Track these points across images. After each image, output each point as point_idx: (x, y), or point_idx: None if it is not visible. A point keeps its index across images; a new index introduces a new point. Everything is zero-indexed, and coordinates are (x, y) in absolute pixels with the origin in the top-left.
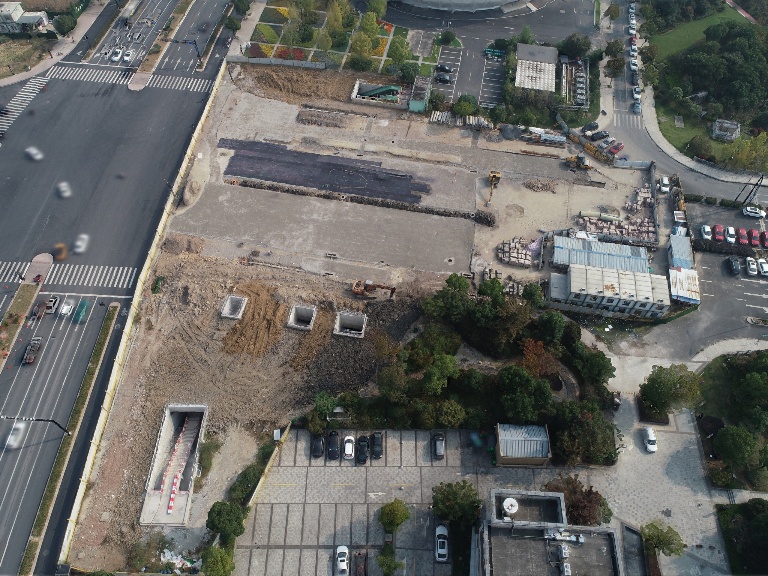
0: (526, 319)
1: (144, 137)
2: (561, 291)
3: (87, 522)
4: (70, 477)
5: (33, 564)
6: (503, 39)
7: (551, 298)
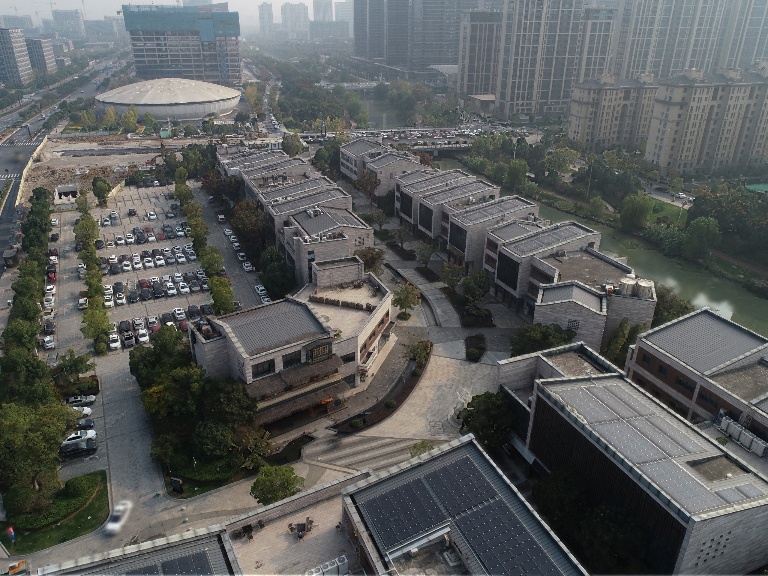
0: None
1: None
2: None
3: None
4: (8, 204)
5: None
6: (206, 121)
7: None
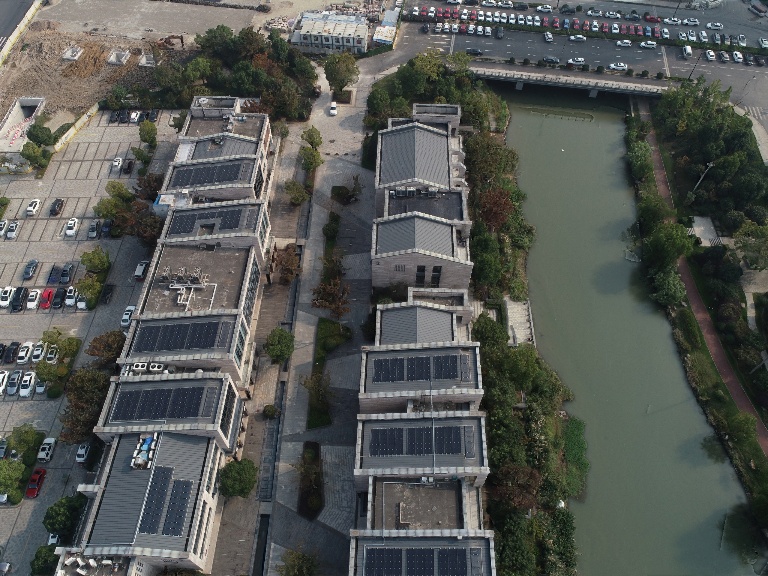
0: (259, 41)
1: None
2: (298, 39)
3: None
4: None
5: None
6: None
7: (291, 43)
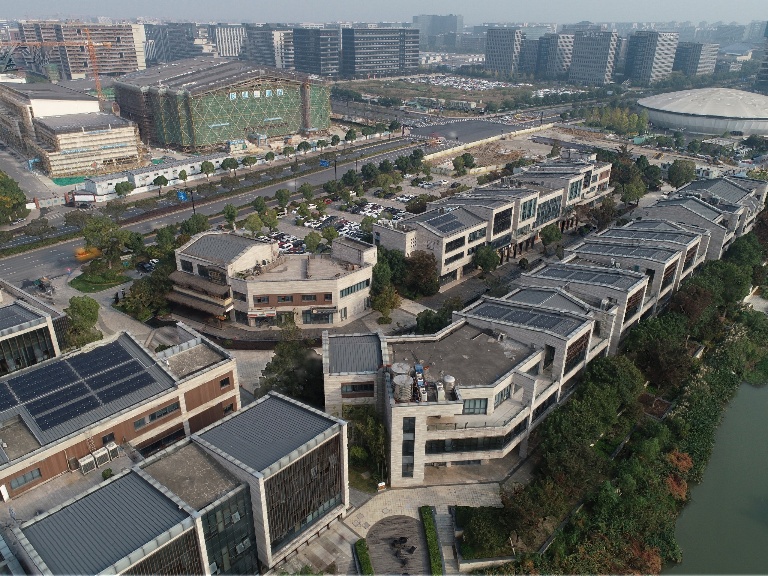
0: (628, 156)
1: None
2: None
3: None
4: None
5: None
6: None
7: None
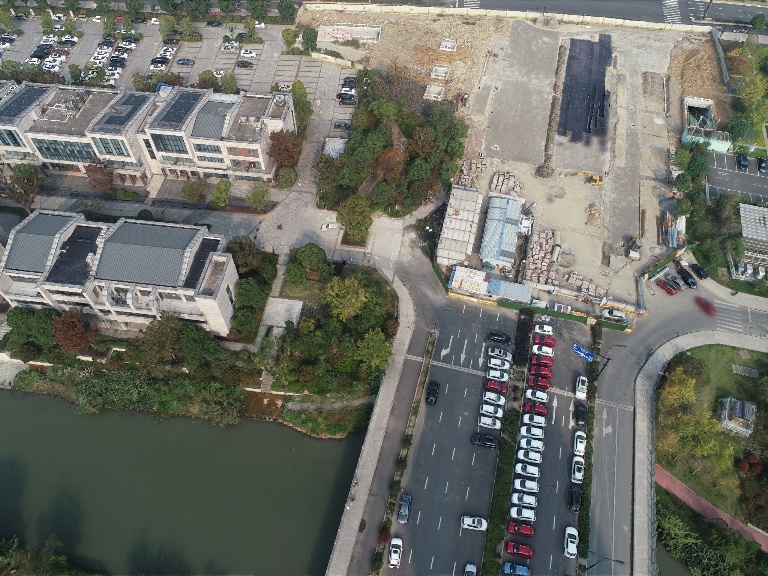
0: None
1: (601, 2)
2: None
3: (324, 13)
4: None
5: (308, 2)
6: None
7: None
